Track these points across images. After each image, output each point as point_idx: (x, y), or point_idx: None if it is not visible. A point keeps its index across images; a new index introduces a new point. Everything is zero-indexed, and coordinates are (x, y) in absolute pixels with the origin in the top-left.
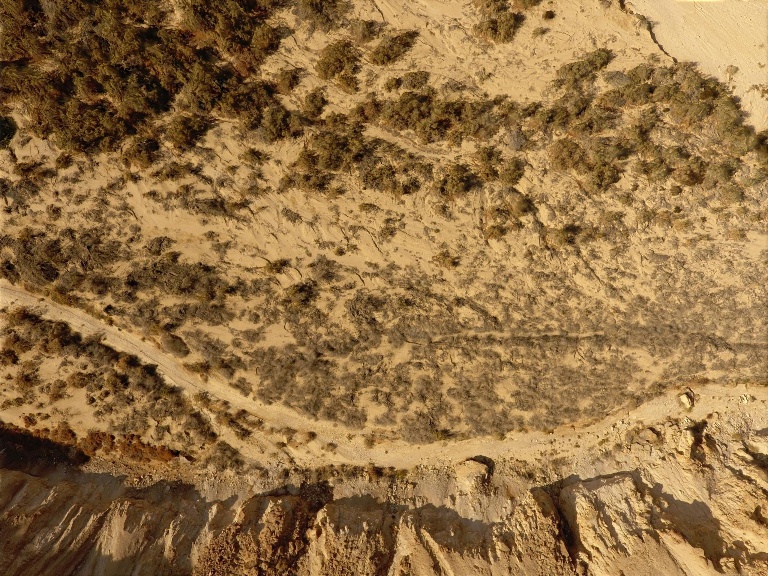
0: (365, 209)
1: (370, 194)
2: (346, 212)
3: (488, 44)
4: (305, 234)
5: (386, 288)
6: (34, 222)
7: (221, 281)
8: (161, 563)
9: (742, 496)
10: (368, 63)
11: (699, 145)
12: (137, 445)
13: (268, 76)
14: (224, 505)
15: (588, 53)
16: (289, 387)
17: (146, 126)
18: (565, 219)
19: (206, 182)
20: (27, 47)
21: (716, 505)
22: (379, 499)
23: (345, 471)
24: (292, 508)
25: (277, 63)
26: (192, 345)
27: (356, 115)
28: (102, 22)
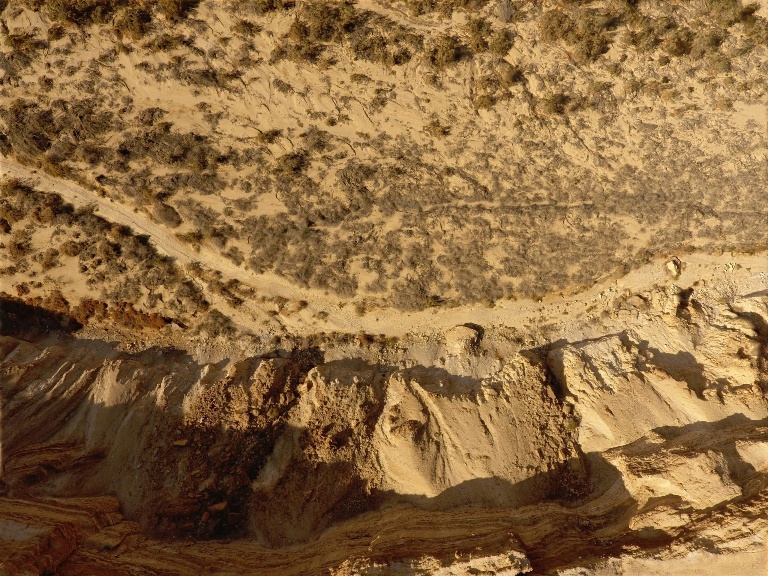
0: (356, 79)
1: (361, 65)
2: (337, 83)
3: None
4: (297, 104)
5: (377, 158)
6: (26, 93)
7: (213, 150)
8: (153, 410)
9: (726, 342)
10: None
11: (687, 16)
12: (130, 312)
13: None
14: (216, 367)
15: None
16: (281, 255)
17: None
18: (554, 89)
19: (198, 53)
20: None
21: (700, 353)
22: (370, 361)
23: (336, 338)
24: (283, 365)
25: None
26: (184, 214)
27: None
28: None
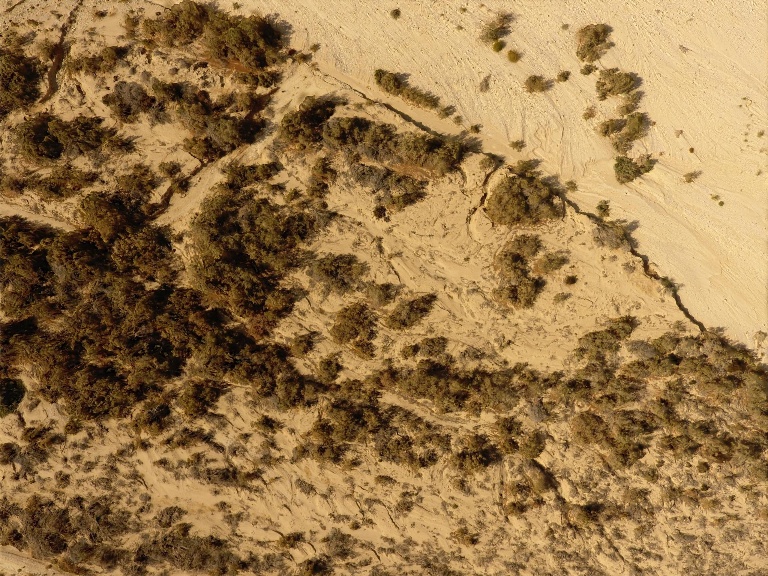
0: (381, 482)
1: (386, 466)
2: (361, 484)
3: (508, 308)
4: (319, 507)
5: (403, 565)
6: (42, 489)
7: (233, 556)
8: None
9: None
10: (384, 327)
11: (727, 419)
12: None
13: (281, 339)
14: None
15: (611, 319)
16: None
17: (157, 391)
18: (588, 496)
19: (218, 451)
20: (36, 312)
21: None
22: None
23: None
24: None
25: (291, 327)
26: None
27: (372, 383)
28: (112, 285)
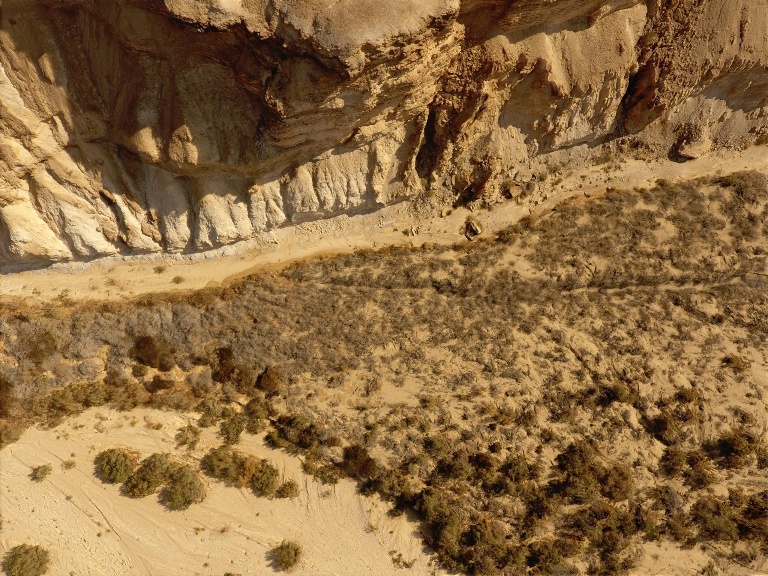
0: None
1: None
2: None
3: None
4: None
5: None
6: None
7: None
8: None
9: None
10: None
11: (472, 499)
12: None
13: None
14: None
15: None
16: None
17: None
18: (612, 413)
19: None
20: None
21: None
22: None
23: None
24: None
25: None
26: None
27: None
28: None
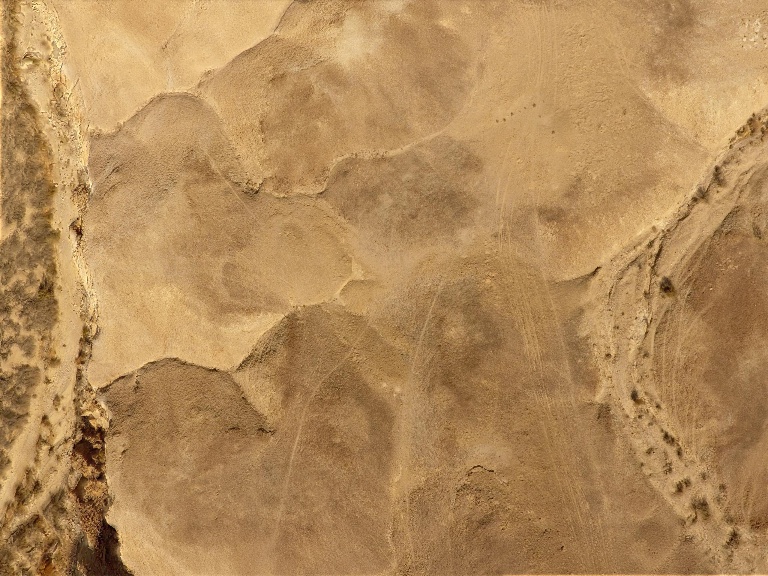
0: None
1: None
2: None
3: None
4: None
5: None
6: None
7: None
8: None
9: None
10: None
11: None
12: None
13: None
14: None
15: None
16: None
17: None
18: None
19: None
20: None
21: None
22: None
23: None
24: (78, 444)
25: None
26: None
27: None
28: None
